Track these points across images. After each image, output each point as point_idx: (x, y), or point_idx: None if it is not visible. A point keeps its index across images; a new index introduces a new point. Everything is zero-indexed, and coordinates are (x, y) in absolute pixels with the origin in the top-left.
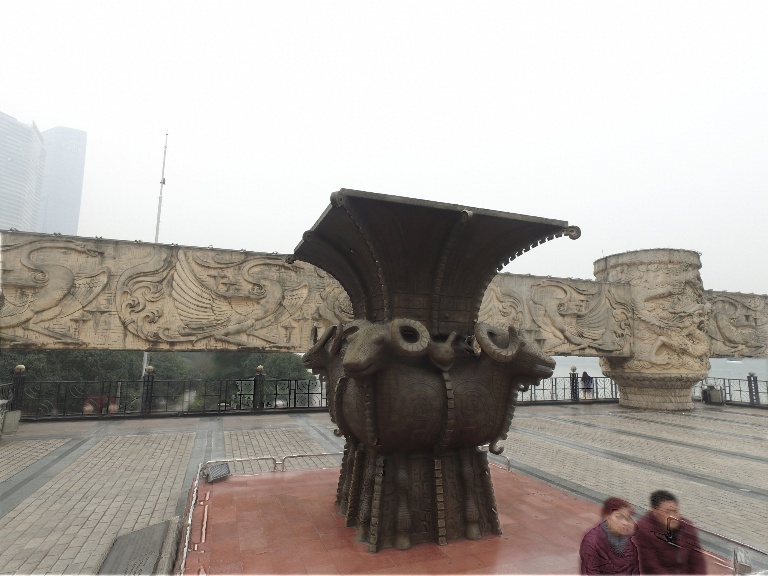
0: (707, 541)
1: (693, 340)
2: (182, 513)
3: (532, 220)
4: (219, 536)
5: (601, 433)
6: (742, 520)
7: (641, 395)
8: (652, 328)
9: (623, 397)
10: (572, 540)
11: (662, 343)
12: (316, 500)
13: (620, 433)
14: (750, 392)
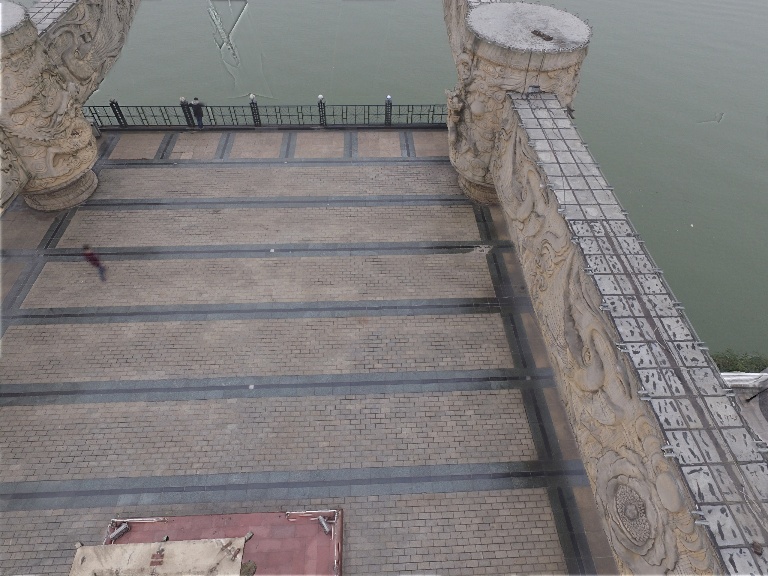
0: (285, 482)
1: (77, 132)
2: None
3: (240, 573)
4: None
5: (105, 335)
6: (277, 438)
7: (54, 199)
8: (36, 143)
9: (33, 202)
10: (270, 568)
11: (54, 154)
12: None
13: (115, 321)
14: (117, 117)
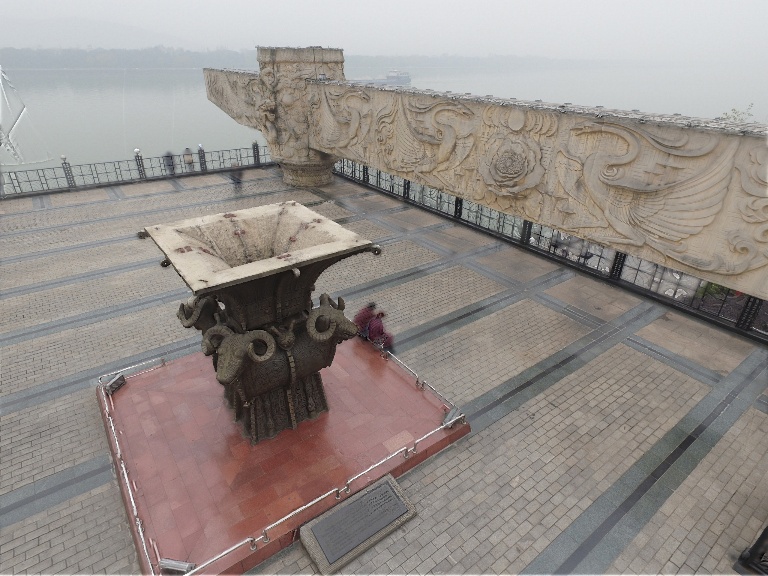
0: None
1: None
2: (246, 575)
3: None
4: (323, 487)
5: None
6: None
7: None
8: None
9: None
10: None
11: None
12: (246, 459)
13: None
14: None
